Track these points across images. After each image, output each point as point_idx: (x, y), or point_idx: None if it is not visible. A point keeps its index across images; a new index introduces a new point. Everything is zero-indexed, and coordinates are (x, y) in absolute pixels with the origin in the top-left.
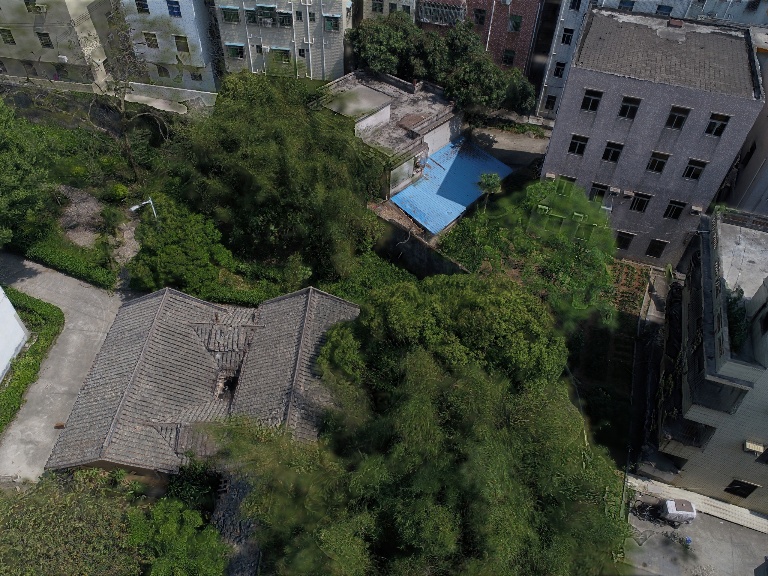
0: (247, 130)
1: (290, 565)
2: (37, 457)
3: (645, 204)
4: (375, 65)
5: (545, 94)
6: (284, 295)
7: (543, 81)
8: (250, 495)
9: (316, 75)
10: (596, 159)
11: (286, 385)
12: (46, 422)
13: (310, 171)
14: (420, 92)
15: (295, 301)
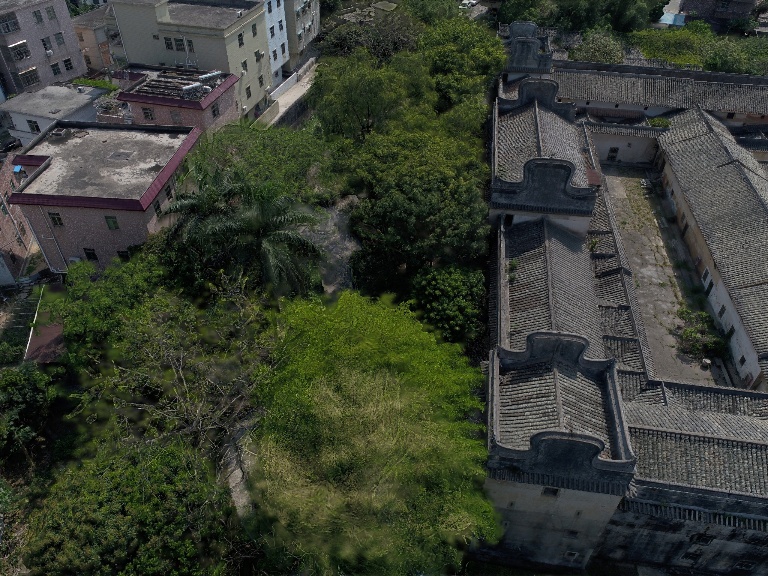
0: (440, 2)
1: None
2: None
3: None
4: (341, 6)
5: None
6: None
7: None
8: (572, 38)
9: (315, 33)
10: None
11: (538, 30)
12: None
13: None
14: None
15: (502, 30)
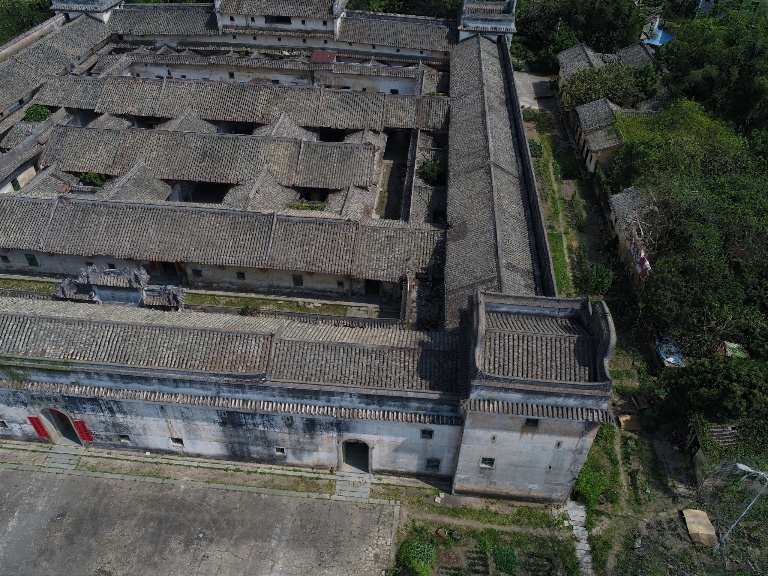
0: None
1: (678, 83)
2: (533, 104)
3: (767, 33)
4: None
5: (699, 12)
6: (629, 46)
7: (699, 5)
8: None
9: None
10: (746, 11)
11: (648, 59)
12: (528, 98)
13: (630, 7)
14: (642, 4)
15: (635, 47)
